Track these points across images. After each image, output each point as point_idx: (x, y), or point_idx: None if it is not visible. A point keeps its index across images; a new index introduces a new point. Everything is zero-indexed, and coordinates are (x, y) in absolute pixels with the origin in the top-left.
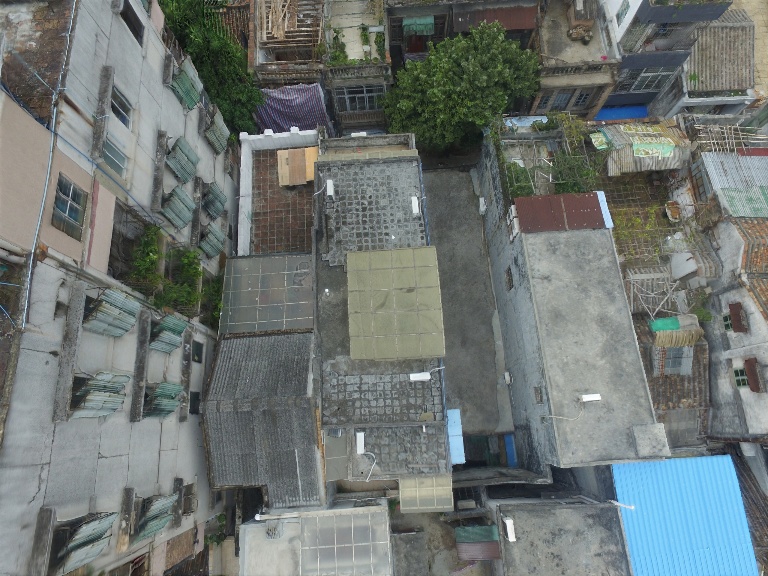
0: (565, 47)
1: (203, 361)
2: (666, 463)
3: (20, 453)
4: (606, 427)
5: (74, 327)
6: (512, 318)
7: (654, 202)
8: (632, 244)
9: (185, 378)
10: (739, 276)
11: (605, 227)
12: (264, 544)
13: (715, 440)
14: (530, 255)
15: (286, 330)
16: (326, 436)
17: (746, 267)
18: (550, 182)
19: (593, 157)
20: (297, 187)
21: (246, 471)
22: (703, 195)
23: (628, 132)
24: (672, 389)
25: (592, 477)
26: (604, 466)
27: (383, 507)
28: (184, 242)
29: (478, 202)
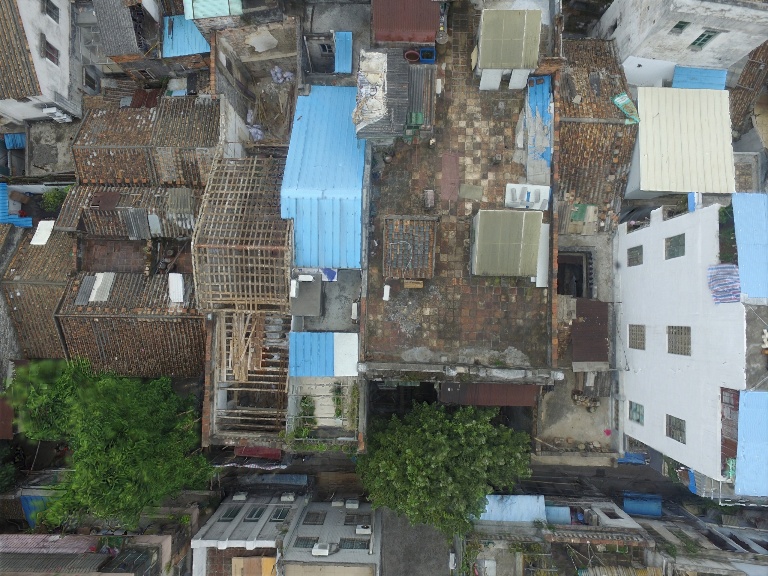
0: (566, 412)
1: None
2: None
3: None
4: None
5: None
6: None
7: None
8: None
9: None
10: None
11: None
12: None
13: None
14: None
15: None
16: None
17: None
18: None
19: None
20: None
21: None
22: None
23: None
24: None
25: None
26: None
27: None
28: None
29: None
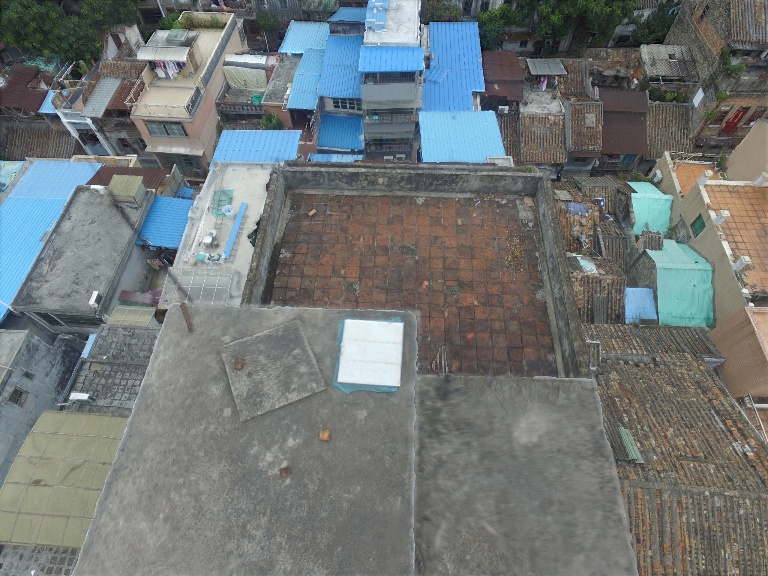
0: None
1: None
2: None
3: None
4: None
5: None
6: None
7: None
8: None
9: None
10: None
11: None
12: None
13: None
14: None
15: None
16: None
17: None
18: None
19: None
20: None
21: None
22: None
23: None
24: None
25: None
26: None
27: None
28: None
29: None
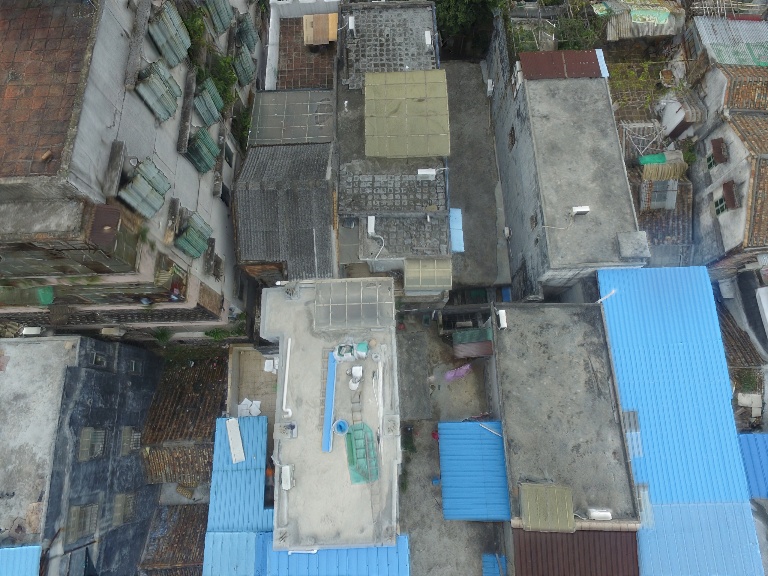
0: None
1: (233, 167)
2: (647, 271)
3: (102, 82)
4: (593, 237)
5: (142, 23)
6: (513, 173)
7: (650, 73)
8: (625, 92)
9: (219, 162)
10: (722, 112)
11: (601, 76)
12: (283, 306)
13: None
14: (531, 98)
15: (308, 142)
16: (341, 226)
17: (728, 102)
18: (553, 40)
19: (593, 21)
20: (320, 48)
21: (269, 247)
22: (694, 54)
23: (627, 2)
24: (658, 226)
25: (580, 297)
26: (591, 283)
27: (389, 278)
28: (222, 52)
29: (486, 87)
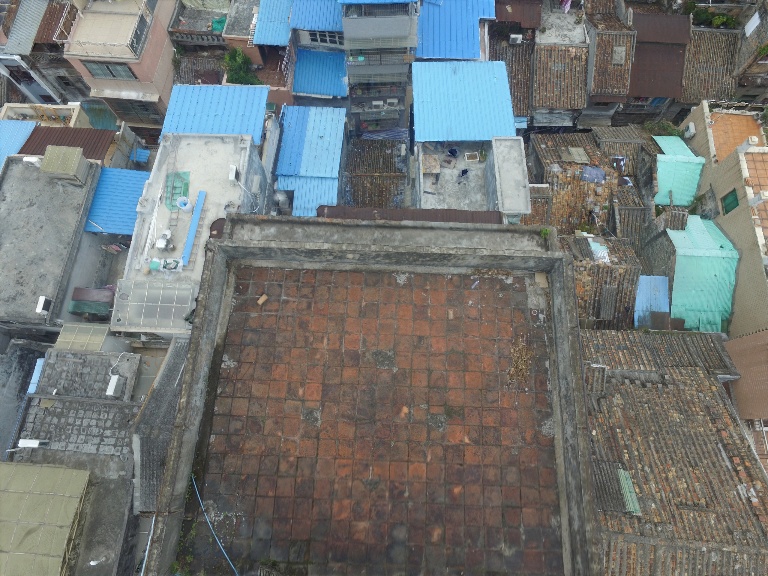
0: None
1: None
2: None
3: None
4: None
5: None
6: None
7: None
8: None
9: None
10: None
11: None
12: None
13: None
14: None
15: None
16: None
17: None
18: None
19: None
20: None
21: None
22: None
23: None
24: None
25: None
26: None
27: None
28: None
29: None
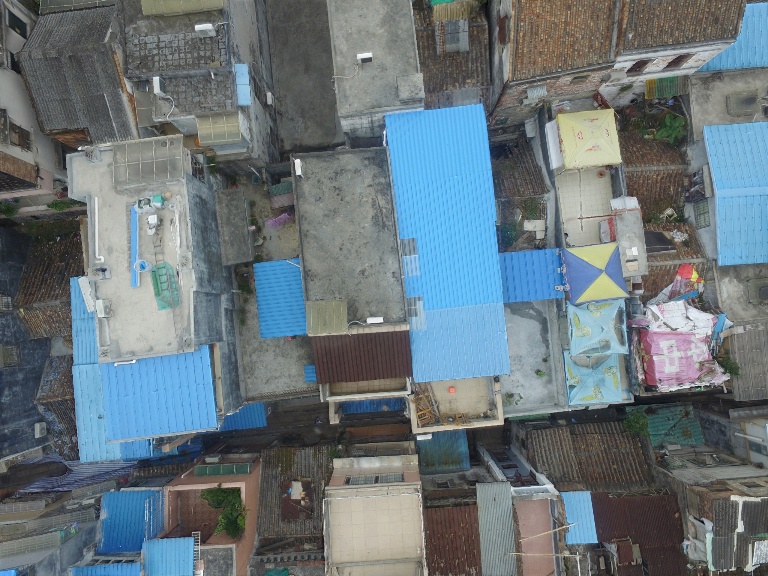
0: None
1: None
2: (429, 113)
3: None
4: (379, 83)
5: None
6: None
7: None
8: None
9: None
10: None
11: None
12: (88, 169)
13: (495, 116)
14: None
15: (96, 6)
16: (135, 90)
17: None
18: None
19: None
20: None
21: (67, 115)
22: None
23: None
24: (458, 70)
25: None
26: None
27: (179, 135)
28: None
29: None
